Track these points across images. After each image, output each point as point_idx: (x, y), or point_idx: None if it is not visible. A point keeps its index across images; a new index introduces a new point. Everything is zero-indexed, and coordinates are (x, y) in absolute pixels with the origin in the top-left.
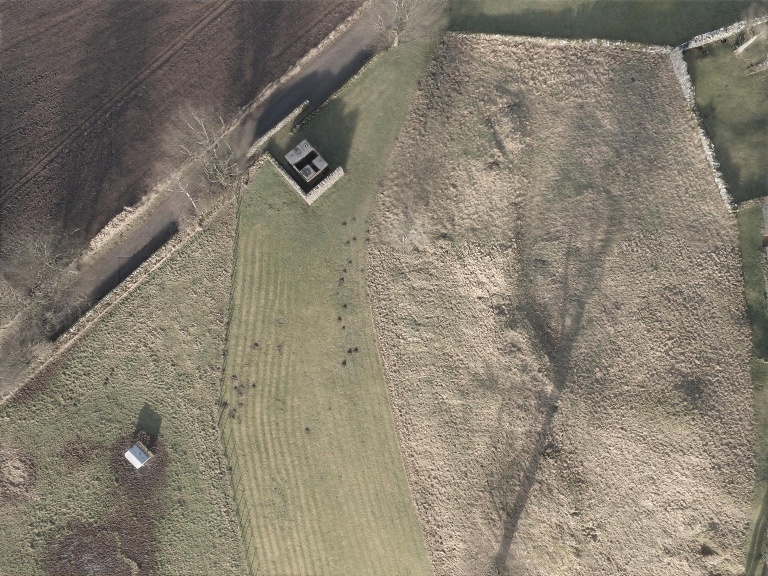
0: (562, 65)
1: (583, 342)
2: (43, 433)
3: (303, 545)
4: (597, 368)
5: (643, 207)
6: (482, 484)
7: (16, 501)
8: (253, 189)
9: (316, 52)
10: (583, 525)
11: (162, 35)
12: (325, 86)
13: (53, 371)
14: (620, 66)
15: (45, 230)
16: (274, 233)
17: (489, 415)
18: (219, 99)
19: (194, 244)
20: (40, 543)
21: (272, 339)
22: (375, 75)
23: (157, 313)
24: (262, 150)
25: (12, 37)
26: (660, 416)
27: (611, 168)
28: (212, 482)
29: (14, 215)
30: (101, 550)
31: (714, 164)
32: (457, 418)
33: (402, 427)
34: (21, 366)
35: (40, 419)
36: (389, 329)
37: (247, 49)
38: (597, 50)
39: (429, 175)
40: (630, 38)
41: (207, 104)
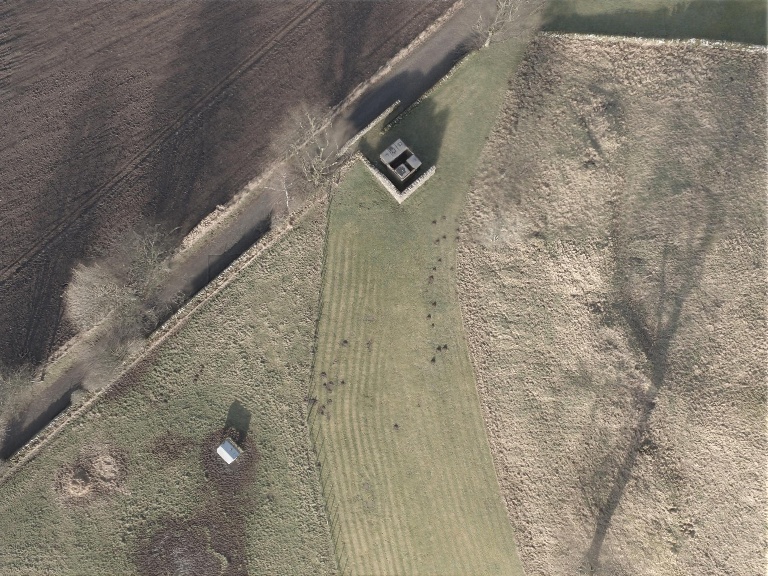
0: (658, 65)
1: (680, 339)
2: (134, 429)
3: (391, 540)
4: (696, 365)
5: (744, 205)
6: (574, 480)
7: (107, 496)
8: (344, 188)
9: (406, 52)
10: (681, 521)
11: (253, 36)
12: (415, 86)
13: (144, 368)
14: (718, 66)
15: (150, 228)
16: (364, 231)
17: (582, 412)
18: (309, 99)
19: (284, 242)
20: (131, 537)
21: (361, 336)
22: (466, 75)
23: (247, 310)
24: (353, 149)
25: (105, 38)
26: (764, 413)
27: (711, 167)
28: (301, 478)
29: (107, 214)
30: (191, 544)
31: None
32: (548, 415)
33: (491, 424)
34: (116, 362)
35: (131, 415)
36: (479, 326)
37: (337, 49)
38: (694, 50)
39: (521, 174)
40: (728, 38)
41: (298, 104)
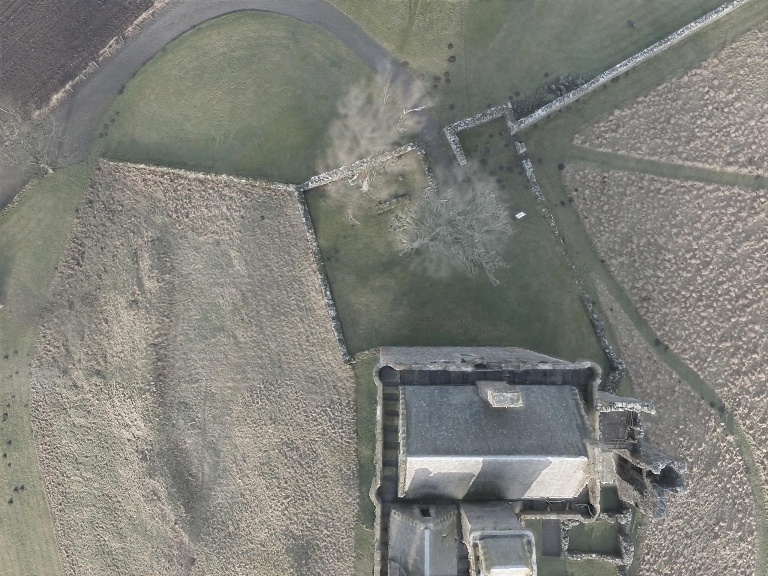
0: (201, 199)
1: (220, 492)
2: None
3: None
4: (229, 521)
5: (265, 355)
6: None
7: None
8: None
9: None
10: None
11: None
12: None
13: None
14: (251, 203)
15: None
16: None
17: (144, 561)
18: None
19: None
20: None
21: None
22: (32, 203)
23: None
24: None
25: None
26: None
27: (237, 313)
28: None
29: None
30: None
31: (330, 312)
32: (118, 561)
33: (69, 568)
34: None
35: None
36: (54, 466)
37: None
38: (231, 185)
39: (84, 308)
40: (263, 172)
41: None
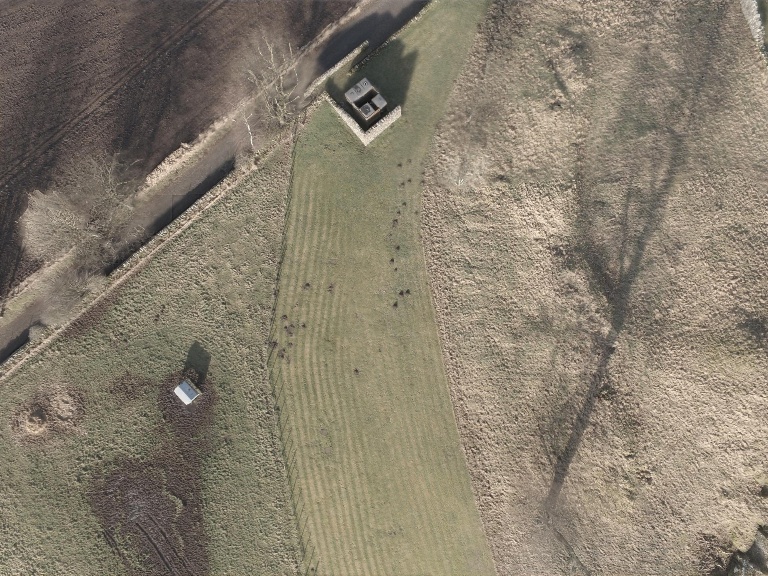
0: (627, 7)
1: (642, 284)
2: (93, 368)
3: (349, 487)
4: (656, 309)
5: (708, 147)
6: (533, 428)
7: (64, 435)
8: (309, 129)
9: None
10: (638, 468)
11: None
12: (384, 28)
13: (105, 306)
14: (687, 7)
15: (108, 157)
16: (329, 173)
17: (542, 358)
18: (278, 39)
19: (249, 183)
20: (87, 477)
21: (324, 280)
22: (435, 17)
23: (209, 251)
24: (320, 90)
25: None
26: (723, 355)
27: (676, 108)
28: (259, 421)
29: (71, 150)
30: (147, 486)
31: None
32: (509, 361)
33: (452, 370)
34: (75, 298)
35: (90, 354)
36: (442, 272)
37: None
38: None
39: (487, 117)
40: None
41: None
